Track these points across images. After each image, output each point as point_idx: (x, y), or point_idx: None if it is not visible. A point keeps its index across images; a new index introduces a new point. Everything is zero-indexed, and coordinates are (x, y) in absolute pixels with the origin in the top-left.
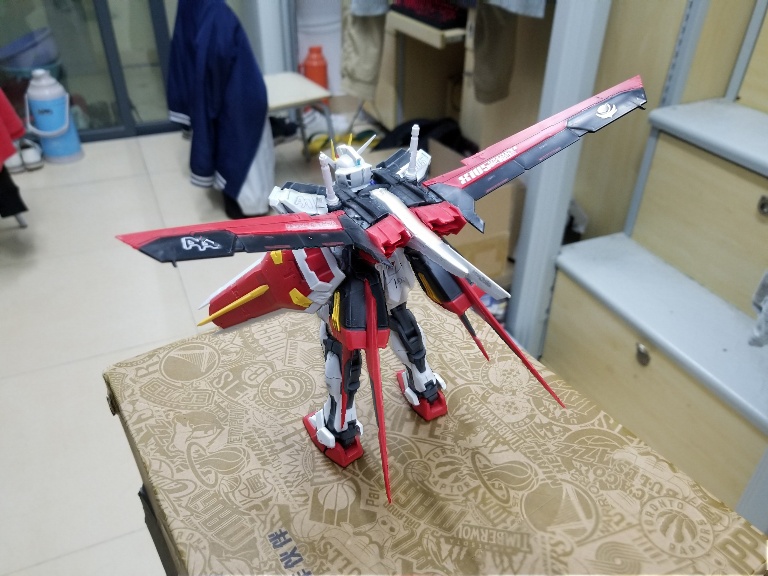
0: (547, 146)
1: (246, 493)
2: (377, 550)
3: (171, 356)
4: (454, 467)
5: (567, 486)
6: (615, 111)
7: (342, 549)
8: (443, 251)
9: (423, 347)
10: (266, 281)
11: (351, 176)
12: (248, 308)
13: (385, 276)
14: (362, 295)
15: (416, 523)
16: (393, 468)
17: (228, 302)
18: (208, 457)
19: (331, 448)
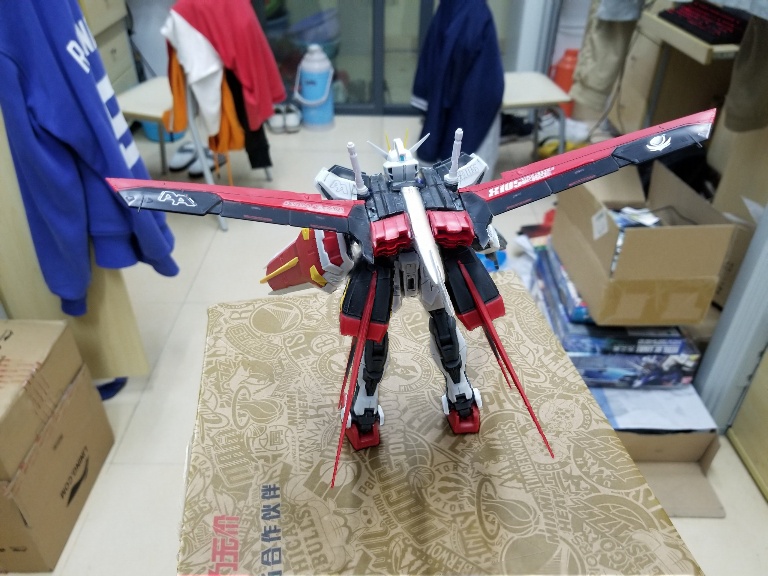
0: (583, 172)
1: (264, 443)
2: (346, 534)
3: (264, 308)
4: (458, 486)
5: (564, 546)
6: (668, 144)
7: (317, 521)
8: (428, 258)
9: (458, 358)
10: (297, 254)
11: (393, 170)
12: (287, 276)
13: (421, 276)
14: (367, 285)
15: (394, 524)
16: (400, 466)
17: (277, 267)
18: (250, 402)
19: (347, 428)
